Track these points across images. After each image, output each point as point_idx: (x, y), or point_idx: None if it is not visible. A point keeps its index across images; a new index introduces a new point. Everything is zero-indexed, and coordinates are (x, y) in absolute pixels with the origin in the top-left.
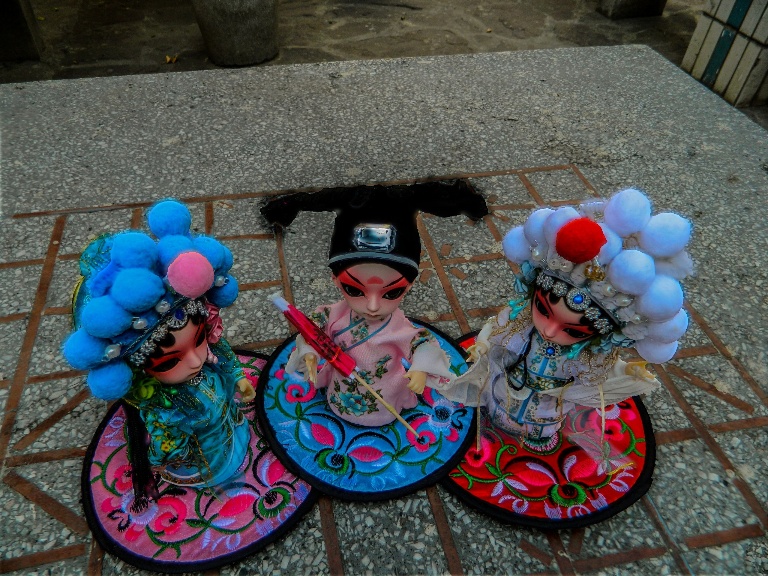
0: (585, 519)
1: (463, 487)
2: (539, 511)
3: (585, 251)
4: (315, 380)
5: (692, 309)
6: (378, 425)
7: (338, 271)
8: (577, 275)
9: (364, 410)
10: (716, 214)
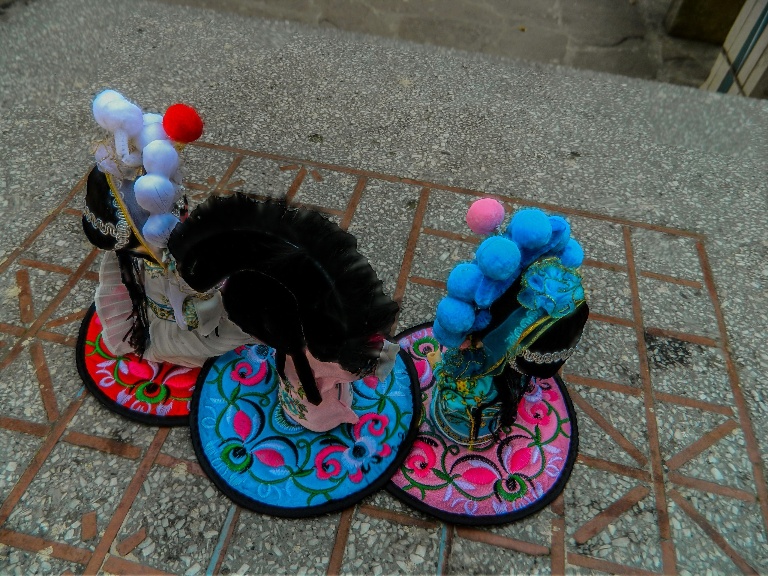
0: None
1: None
2: None
3: None
4: None
5: None
6: None
7: None
8: None
9: None
10: None
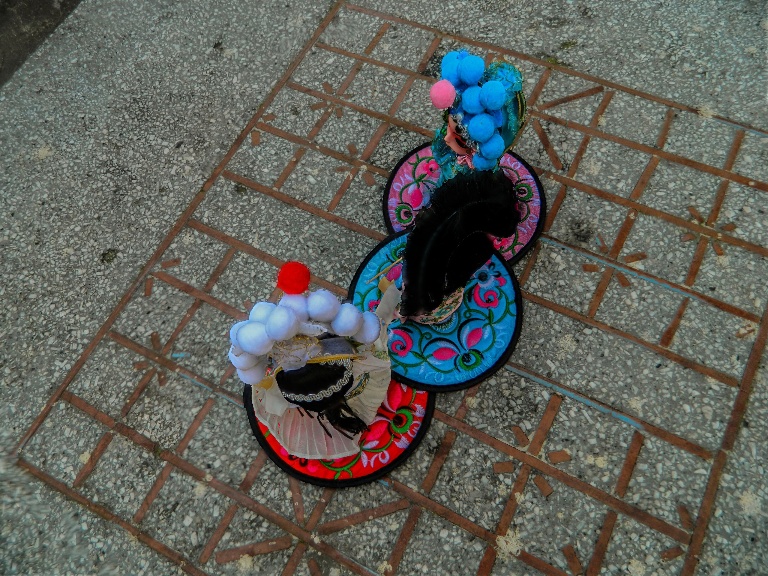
0: None
1: None
2: None
3: None
4: None
5: None
6: None
7: None
8: None
9: None
10: None
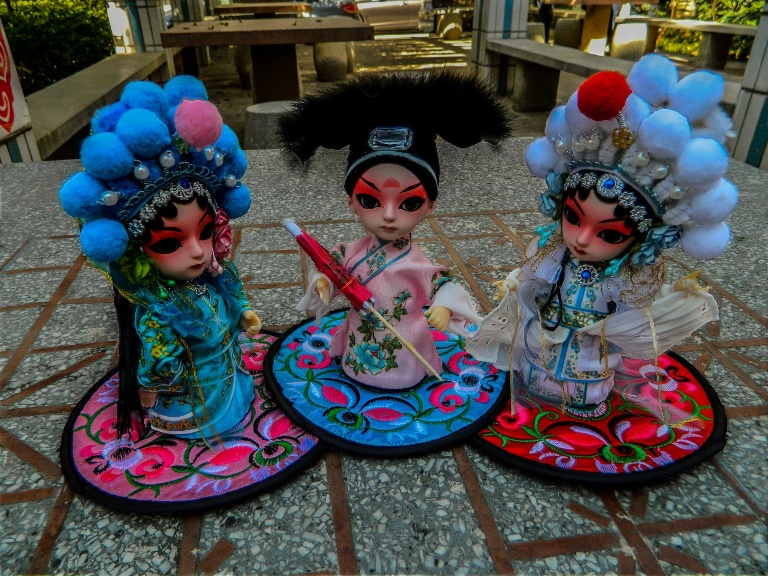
0: (647, 473)
1: (495, 444)
2: (589, 466)
3: (609, 96)
4: (326, 301)
5: (748, 308)
6: (397, 387)
7: (353, 182)
8: (605, 150)
9: (381, 366)
10: (760, 238)
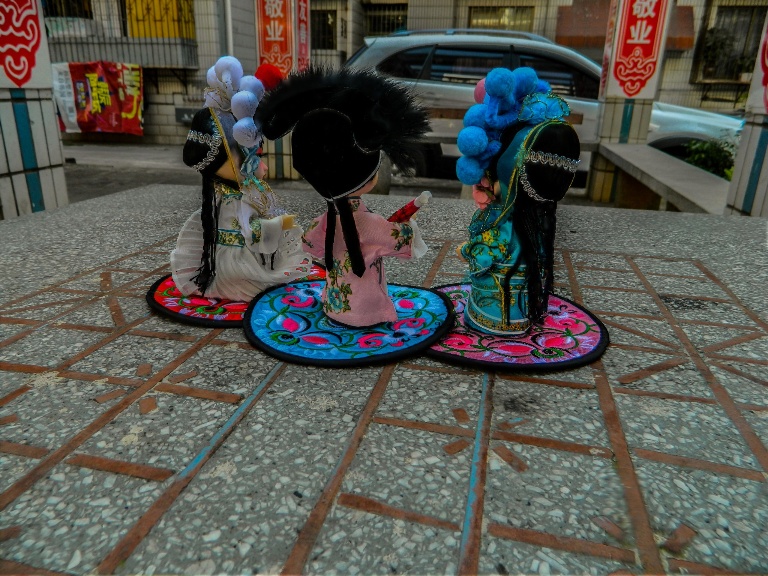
0: None
1: None
2: None
3: None
4: None
5: (6, 304)
6: None
7: None
8: None
9: None
10: None
